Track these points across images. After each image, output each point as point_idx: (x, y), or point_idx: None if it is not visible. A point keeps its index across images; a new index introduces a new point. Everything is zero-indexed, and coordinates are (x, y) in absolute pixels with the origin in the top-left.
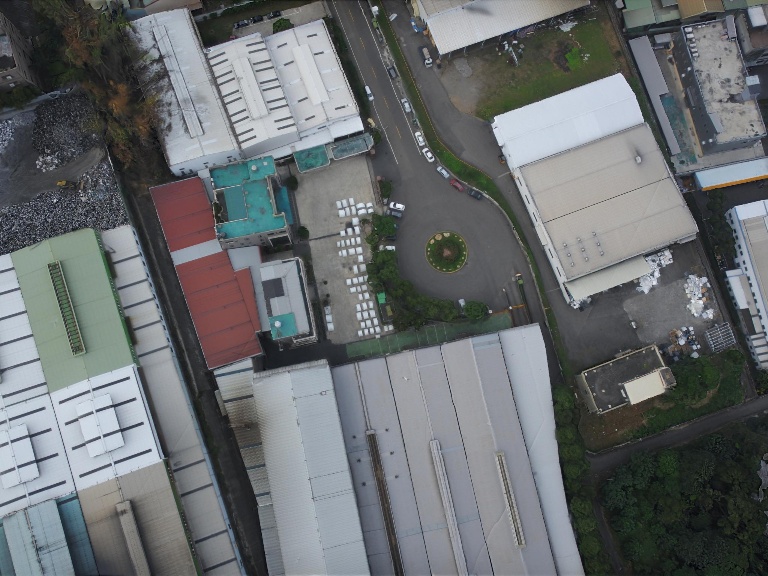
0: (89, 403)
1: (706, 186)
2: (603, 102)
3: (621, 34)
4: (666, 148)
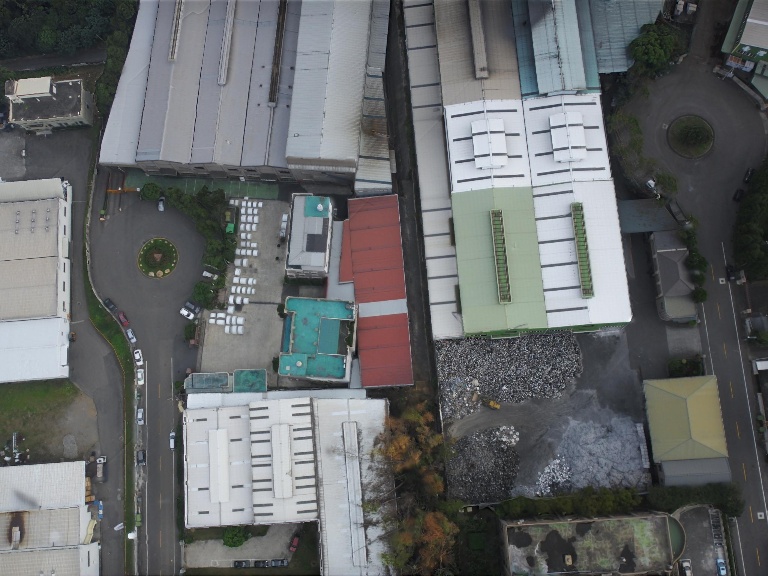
0: (495, 164)
1: None
2: None
3: None
4: None
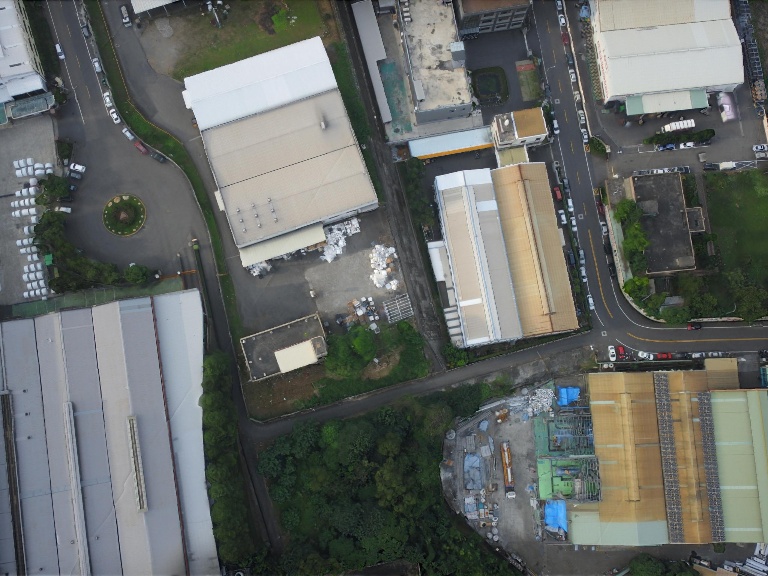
0: None
1: (417, 155)
2: (294, 65)
3: None
4: (375, 115)
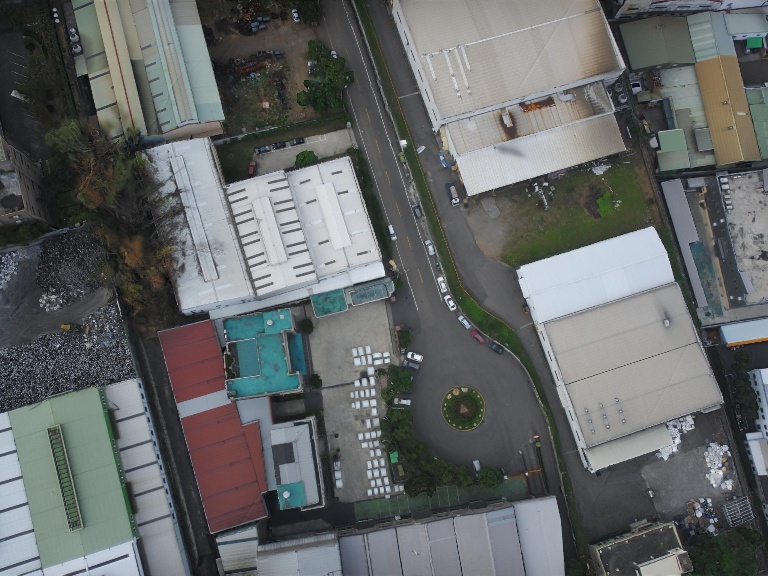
0: None
1: (731, 342)
2: (634, 258)
3: (655, 180)
4: (693, 301)
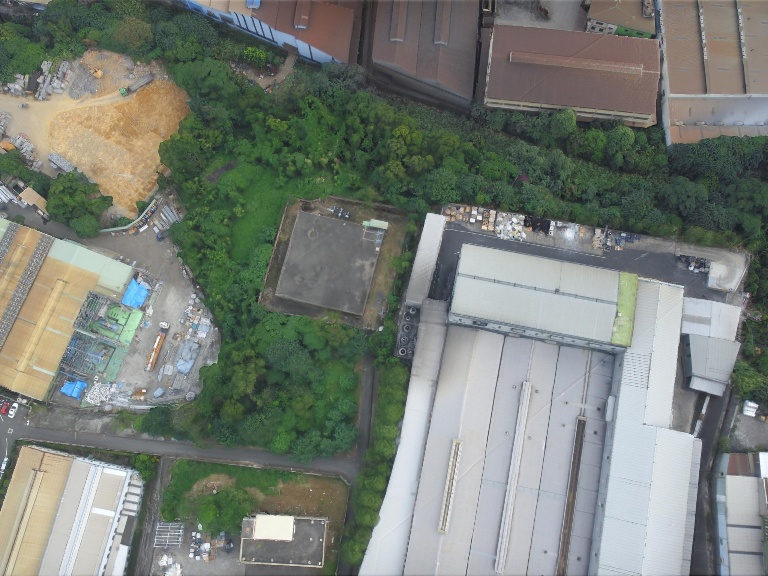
0: None
1: None
2: None
3: None
4: None
